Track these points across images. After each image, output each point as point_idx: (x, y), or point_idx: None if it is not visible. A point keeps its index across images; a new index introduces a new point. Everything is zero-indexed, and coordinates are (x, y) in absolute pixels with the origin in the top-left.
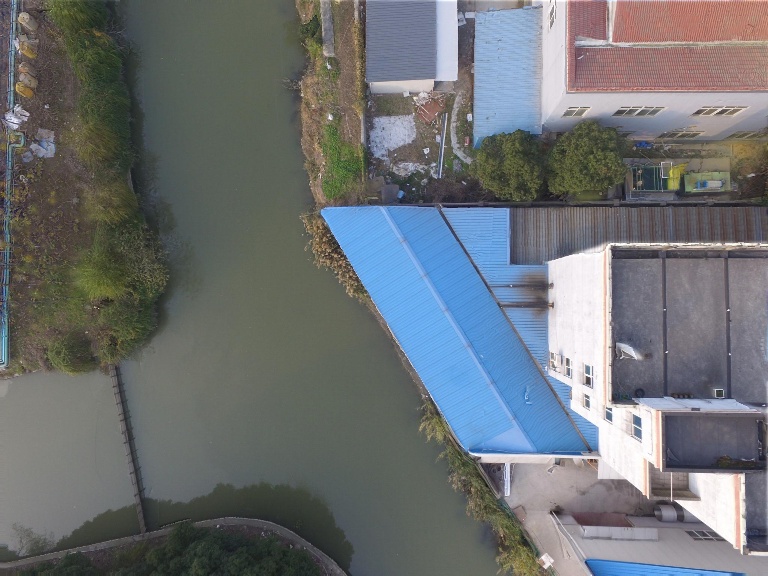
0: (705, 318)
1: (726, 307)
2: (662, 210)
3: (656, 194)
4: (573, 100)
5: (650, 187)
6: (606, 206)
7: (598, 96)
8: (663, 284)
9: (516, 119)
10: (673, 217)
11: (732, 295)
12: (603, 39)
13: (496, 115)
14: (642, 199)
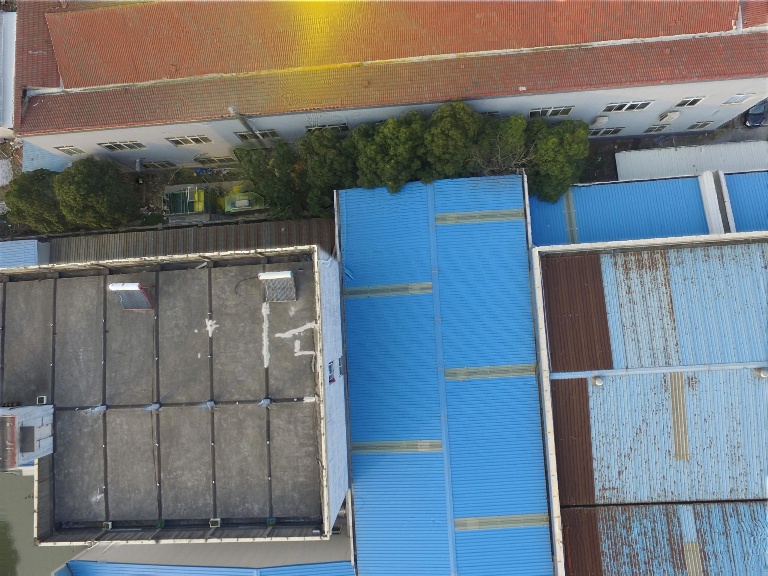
0: (36, 333)
1: (53, 322)
2: (185, 231)
3: (188, 216)
4: (39, 142)
5: (179, 211)
6: (153, 230)
7: (51, 137)
8: (3, 305)
9: (54, 158)
10: (194, 237)
11: (58, 311)
12: (57, 87)
13: (39, 156)
14: (183, 221)
